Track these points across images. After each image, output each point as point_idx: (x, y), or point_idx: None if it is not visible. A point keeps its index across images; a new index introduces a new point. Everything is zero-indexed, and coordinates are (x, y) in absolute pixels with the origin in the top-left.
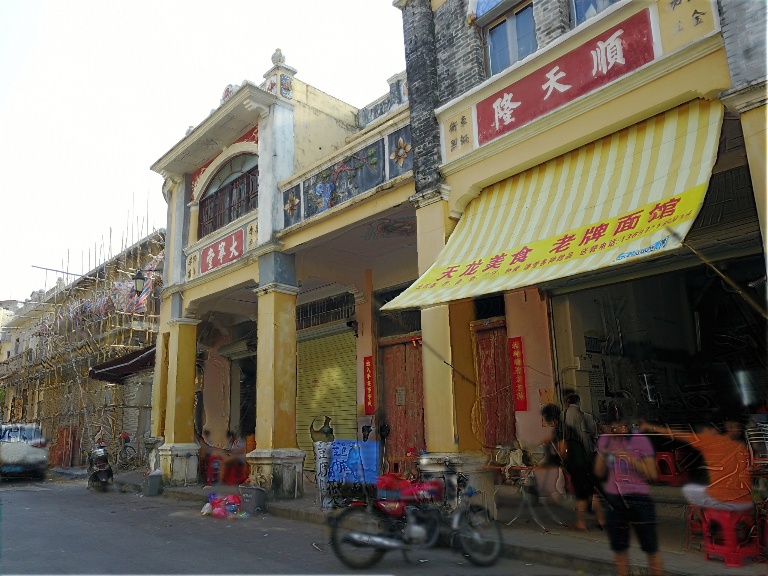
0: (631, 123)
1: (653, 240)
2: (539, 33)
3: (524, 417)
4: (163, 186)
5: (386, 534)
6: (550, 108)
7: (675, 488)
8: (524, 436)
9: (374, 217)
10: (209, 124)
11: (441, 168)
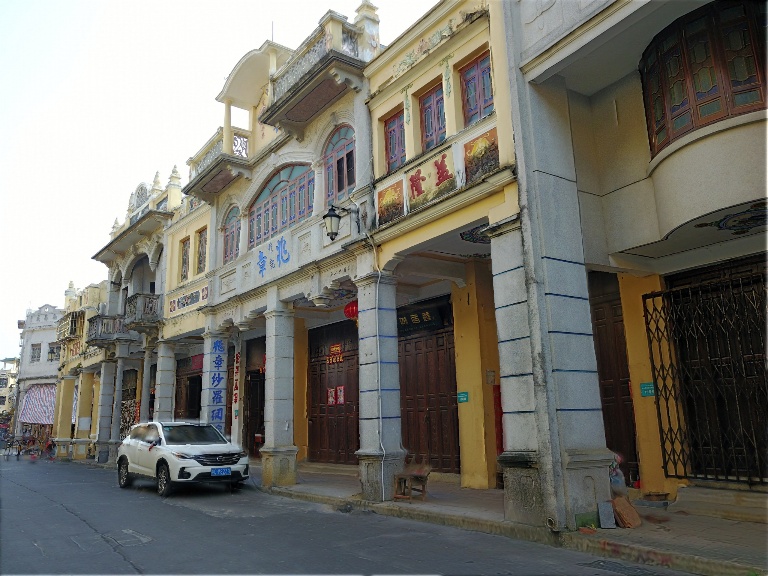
0: None
1: None
2: None
3: None
4: None
5: None
6: None
7: None
8: None
9: None
10: (11, 375)
11: None
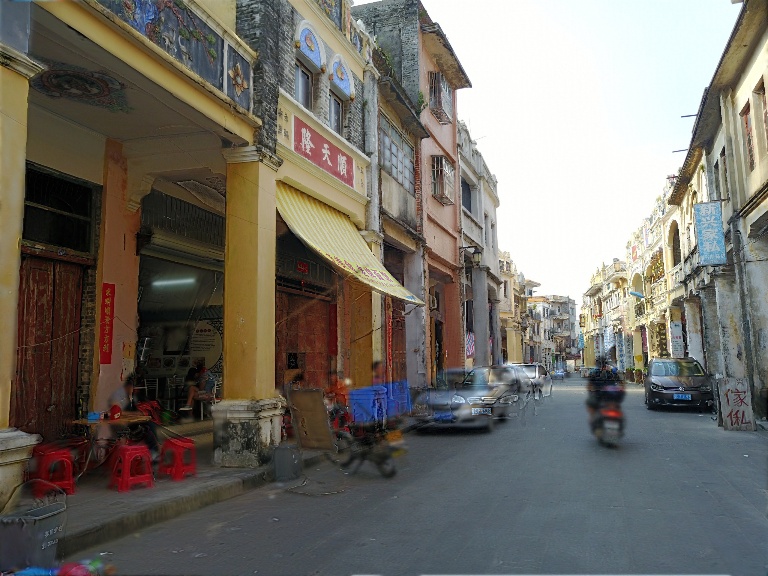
0: (335, 207)
1: (407, 294)
2: (322, 111)
3: (110, 371)
4: None
5: (251, 487)
6: (325, 168)
7: (191, 424)
8: (105, 391)
9: (190, 111)
10: None
11: (278, 143)
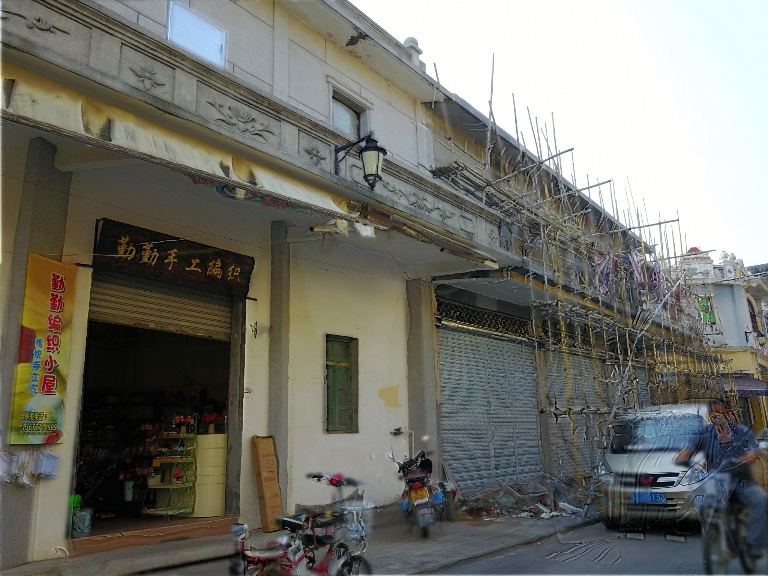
0: None
1: None
2: None
3: None
4: (743, 281)
5: None
6: None
7: None
8: None
9: None
10: None
11: None
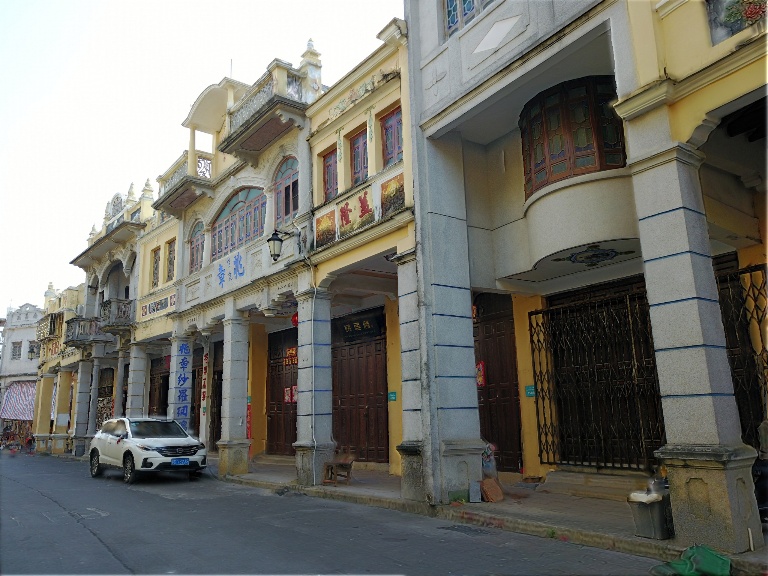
0: None
1: None
2: None
3: None
4: None
5: None
6: None
7: None
8: None
9: None
10: None
11: None
